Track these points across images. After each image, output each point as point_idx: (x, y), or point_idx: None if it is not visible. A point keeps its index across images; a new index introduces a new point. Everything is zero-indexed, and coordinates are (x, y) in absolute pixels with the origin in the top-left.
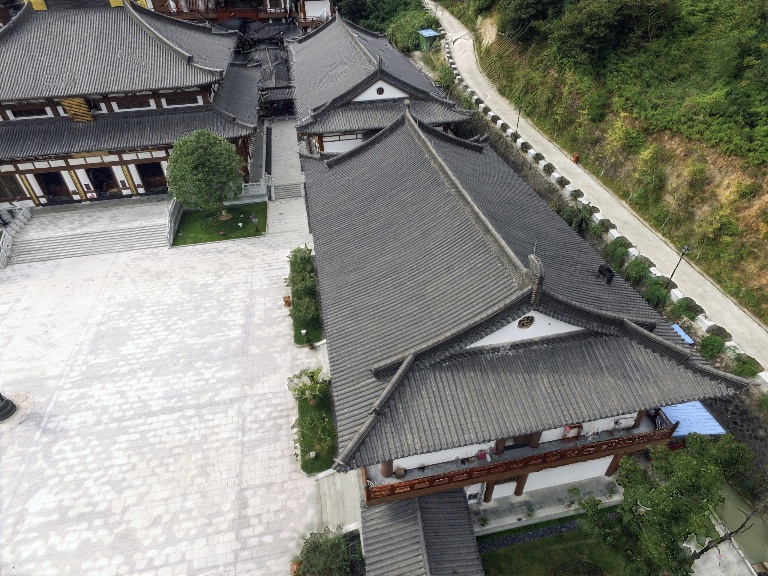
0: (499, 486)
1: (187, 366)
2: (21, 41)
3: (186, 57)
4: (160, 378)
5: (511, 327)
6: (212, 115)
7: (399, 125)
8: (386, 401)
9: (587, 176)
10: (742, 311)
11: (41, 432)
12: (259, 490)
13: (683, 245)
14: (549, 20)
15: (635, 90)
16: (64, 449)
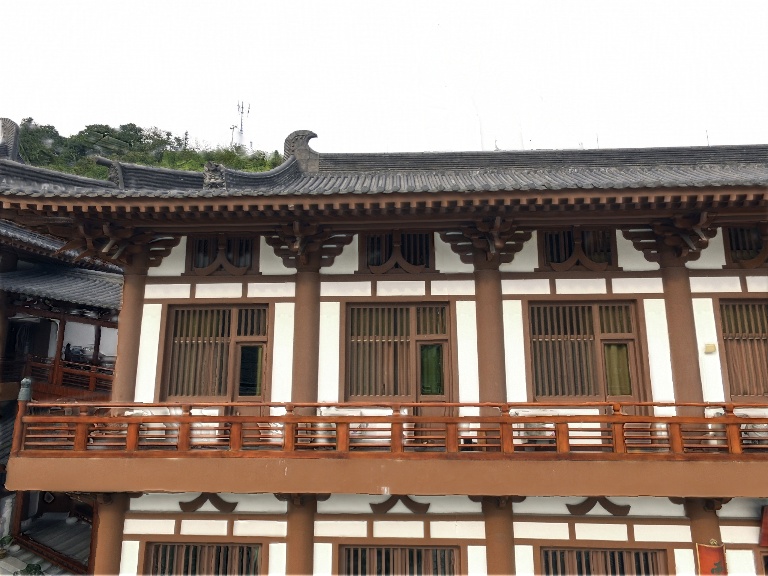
0: None
1: None
2: None
3: None
4: None
5: None
6: None
7: (292, 174)
8: None
9: None
10: None
11: None
12: None
13: None
14: None
15: None
16: None
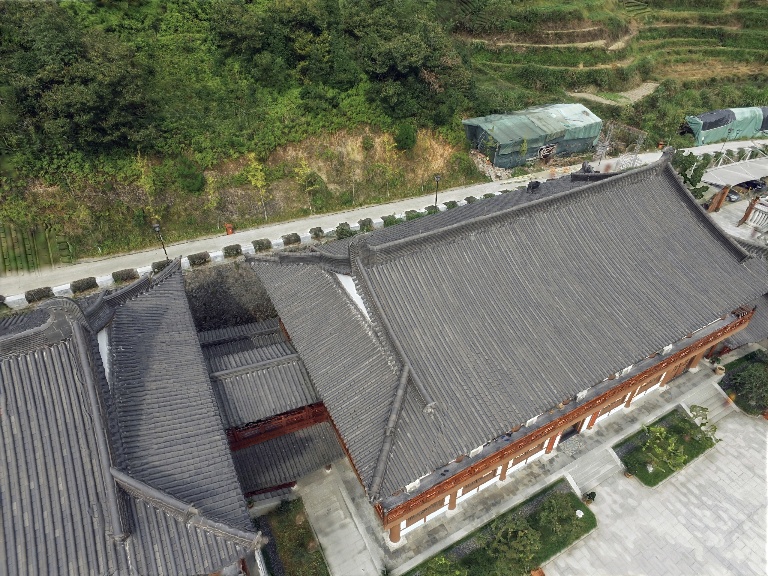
0: None
1: None
2: None
3: None
4: None
5: None
6: None
7: None
8: None
9: (264, 229)
10: (435, 194)
11: None
12: (761, 474)
13: (375, 199)
14: None
15: (208, 137)
16: None
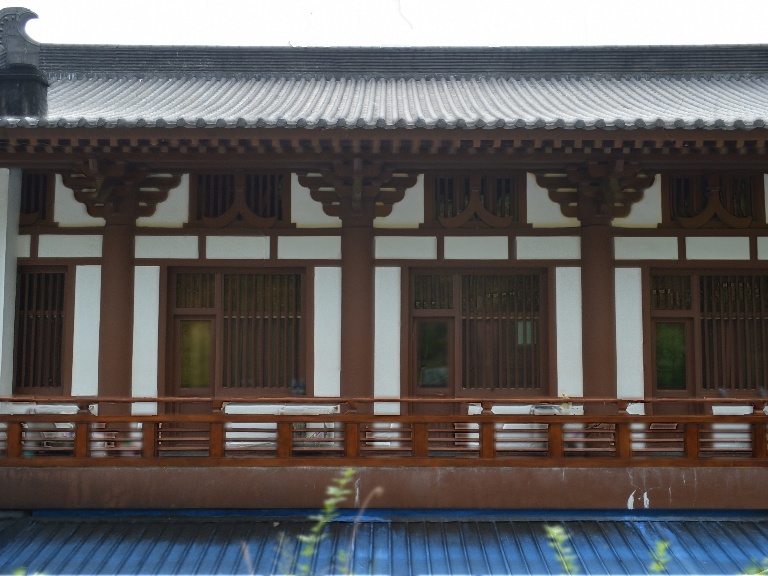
0: None
1: None
2: None
3: None
4: None
5: None
6: None
7: None
8: None
9: None
10: None
11: None
12: None
13: None
14: None
15: None
16: None
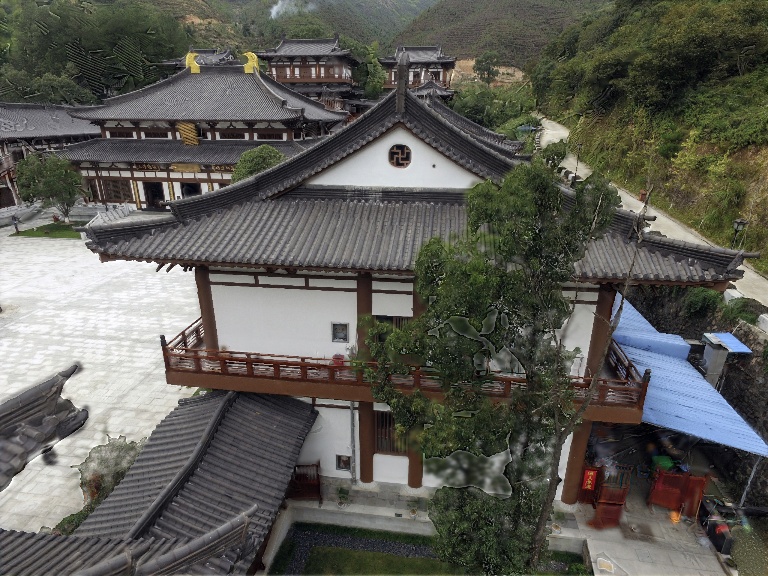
0: (382, 456)
1: (155, 313)
2: (172, 90)
3: (281, 101)
4: (125, 316)
5: (379, 160)
6: (291, 149)
7: None
8: (193, 205)
9: (652, 210)
10: None
11: (0, 330)
12: (128, 412)
13: (765, 263)
14: None
15: (715, 116)
16: (3, 344)
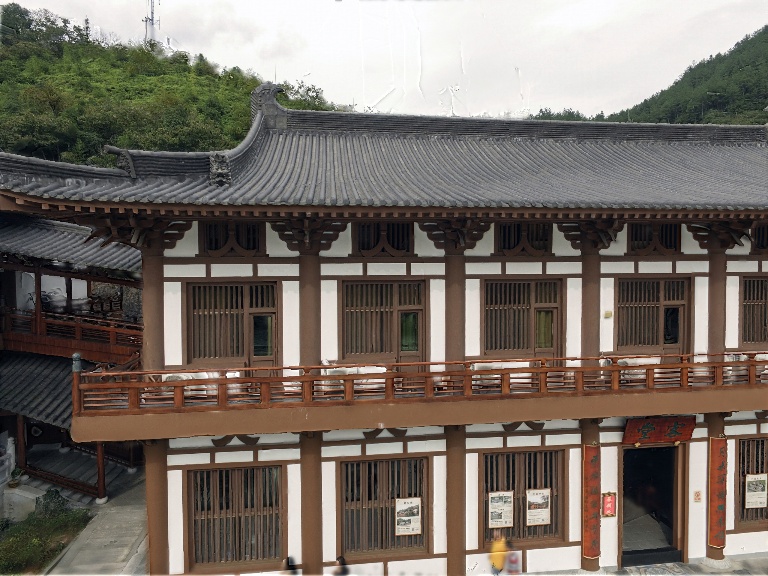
0: None
1: None
2: None
3: None
4: None
5: None
6: None
7: (262, 131)
8: None
9: None
10: None
11: None
12: None
13: None
14: (79, 156)
15: None
16: None
